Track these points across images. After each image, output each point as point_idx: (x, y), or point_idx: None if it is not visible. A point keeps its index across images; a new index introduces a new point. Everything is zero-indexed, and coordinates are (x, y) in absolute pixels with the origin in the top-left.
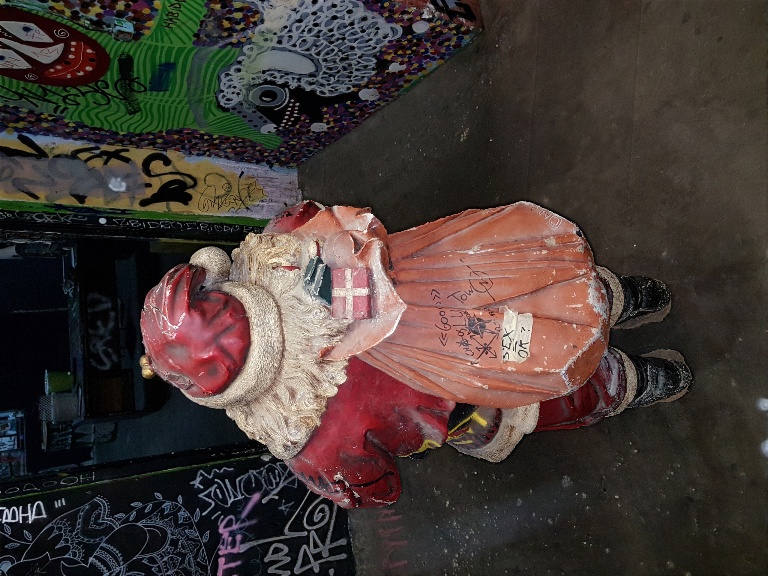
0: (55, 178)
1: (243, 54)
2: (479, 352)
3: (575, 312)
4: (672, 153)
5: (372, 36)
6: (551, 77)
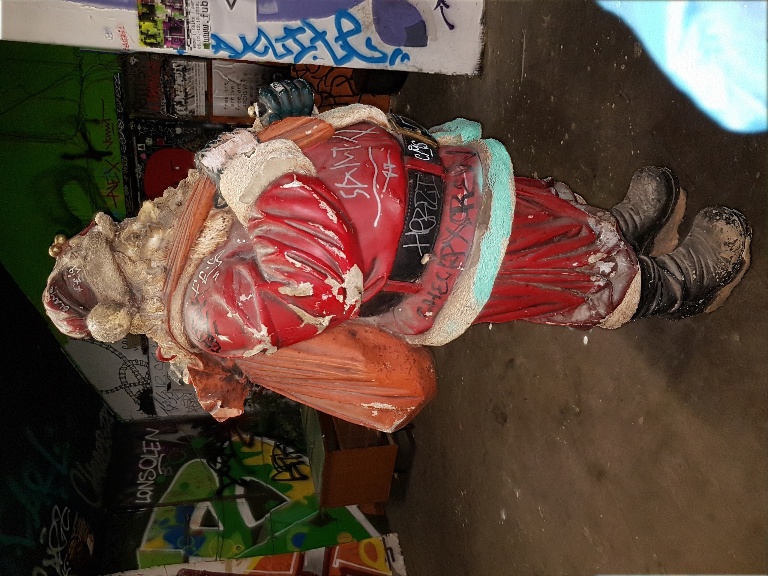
0: None
1: None
2: None
3: None
4: None
5: None
6: None
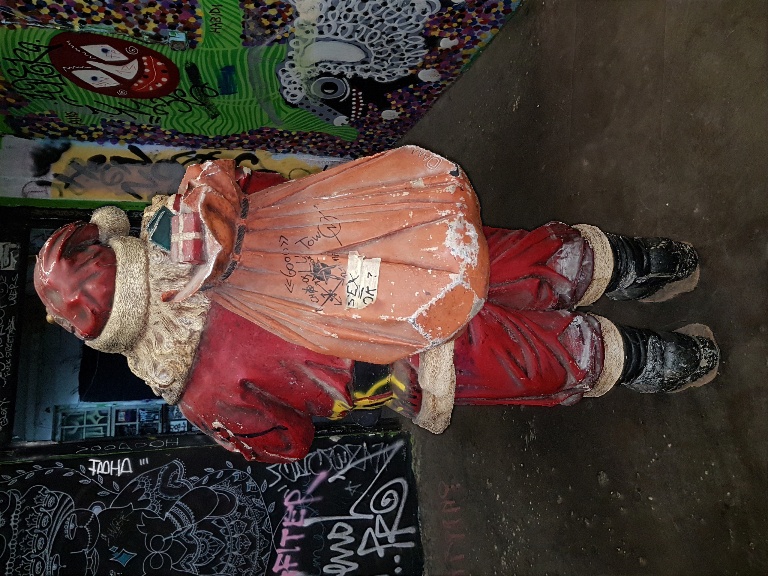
0: (156, 180)
1: (291, 49)
2: (324, 299)
3: (430, 256)
4: (701, 90)
5: (410, 13)
6: (589, 26)
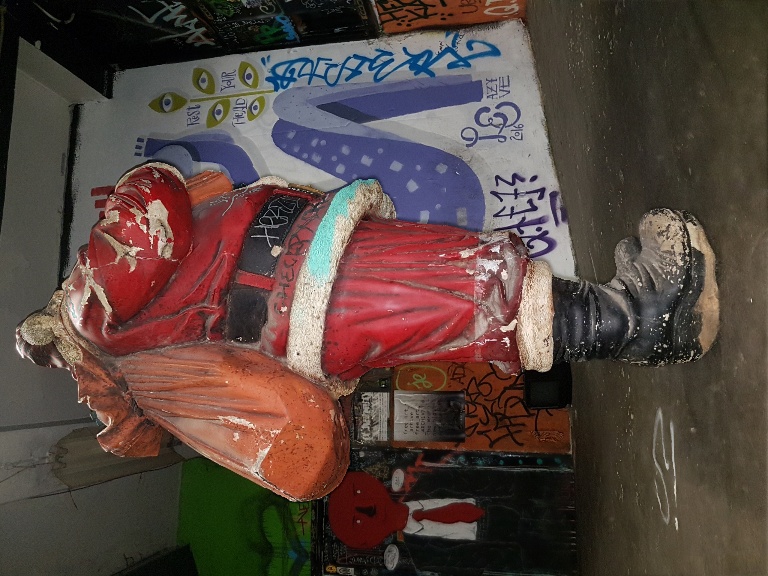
0: None
1: None
2: None
3: None
4: None
5: None
6: None
